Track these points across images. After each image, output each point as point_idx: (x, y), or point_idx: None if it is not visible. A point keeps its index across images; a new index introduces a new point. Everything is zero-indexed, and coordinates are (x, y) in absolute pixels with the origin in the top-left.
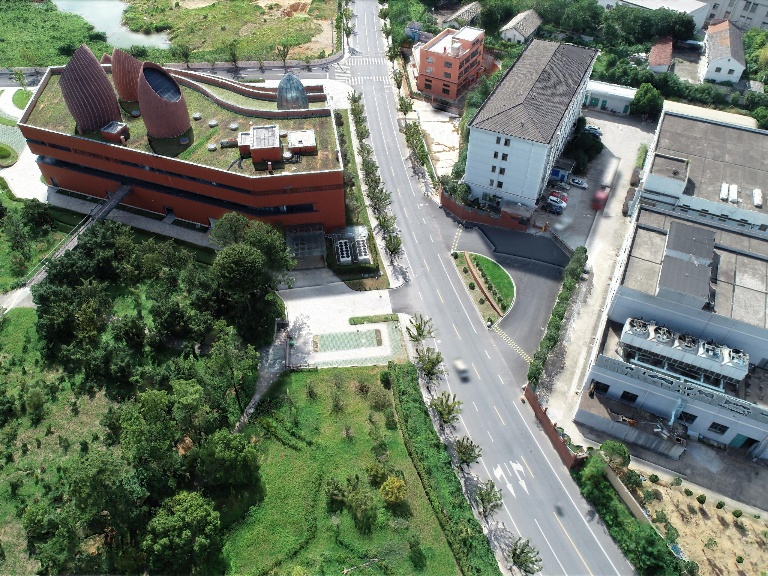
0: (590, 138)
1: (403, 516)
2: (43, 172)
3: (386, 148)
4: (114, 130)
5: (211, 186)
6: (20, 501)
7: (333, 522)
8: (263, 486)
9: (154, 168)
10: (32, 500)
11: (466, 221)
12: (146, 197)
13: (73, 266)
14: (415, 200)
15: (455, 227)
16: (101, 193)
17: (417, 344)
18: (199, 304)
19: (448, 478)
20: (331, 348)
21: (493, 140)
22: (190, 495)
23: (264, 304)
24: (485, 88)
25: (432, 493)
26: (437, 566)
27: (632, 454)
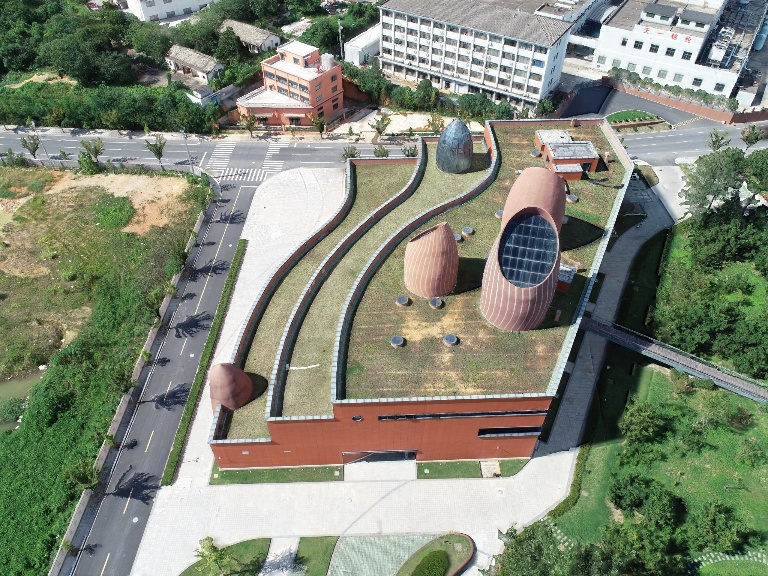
0: None
1: None
2: (536, 441)
3: None
4: (563, 273)
5: None
6: None
7: None
8: None
9: None
10: None
11: None
12: None
13: None
14: None
15: None
16: None
17: None
18: None
19: None
20: None
21: None
22: None
23: None
24: None
25: None
26: None
27: (763, 94)
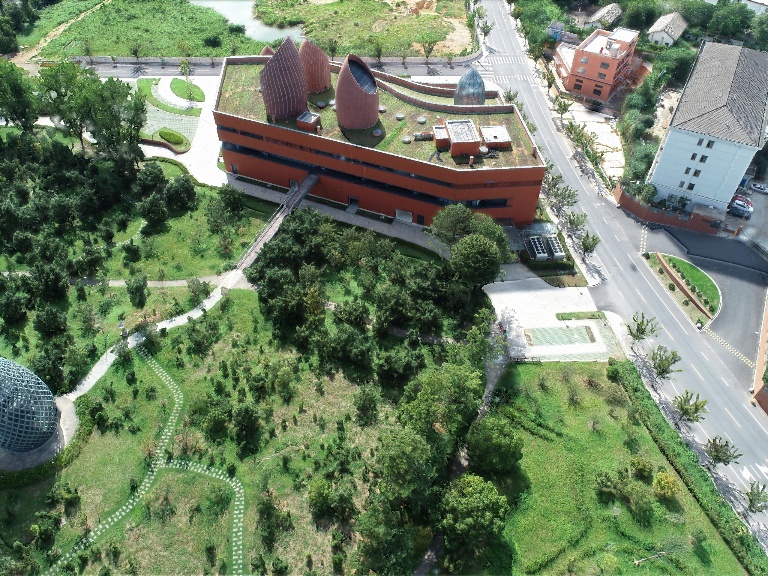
0: (767, 143)
1: (677, 511)
2: (225, 159)
3: (548, 147)
4: (309, 120)
5: (409, 178)
6: (294, 475)
7: (611, 513)
8: (525, 474)
9: (350, 158)
10: (305, 475)
11: (649, 222)
12: (332, 187)
13: (288, 251)
14: (590, 199)
15: (639, 228)
16: (283, 181)
17: (638, 342)
18: (420, 293)
19: (705, 477)
20: (545, 342)
21: (694, 141)
22: (476, 478)
23: (480, 296)
24: (645, 90)
25: (697, 490)
26: (721, 563)
27: None
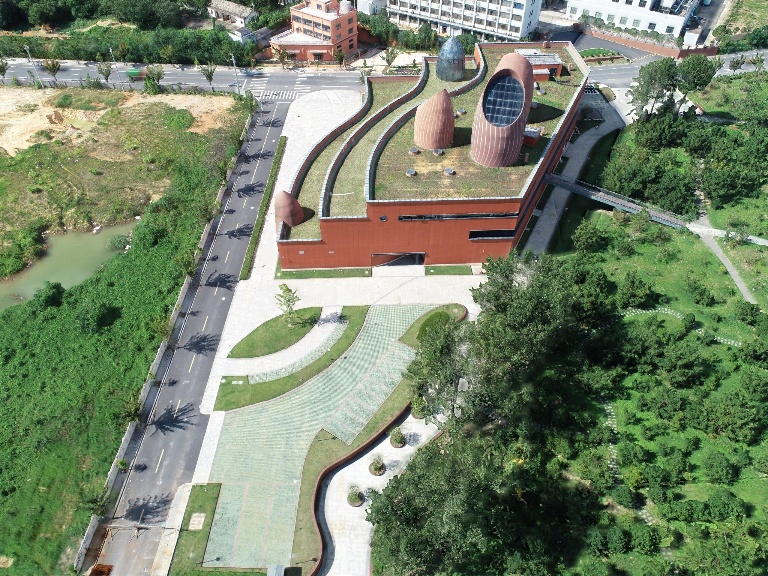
0: None
1: None
2: None
3: None
4: (532, 133)
5: None
6: None
7: None
8: None
9: None
10: None
11: None
12: None
13: None
14: None
15: None
16: None
17: None
18: None
19: None
20: None
21: None
22: None
23: None
24: None
25: None
26: None
27: None
